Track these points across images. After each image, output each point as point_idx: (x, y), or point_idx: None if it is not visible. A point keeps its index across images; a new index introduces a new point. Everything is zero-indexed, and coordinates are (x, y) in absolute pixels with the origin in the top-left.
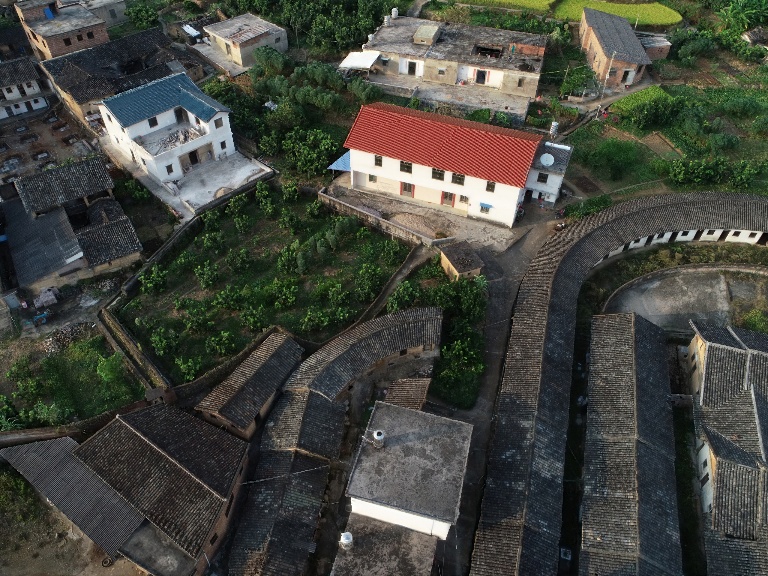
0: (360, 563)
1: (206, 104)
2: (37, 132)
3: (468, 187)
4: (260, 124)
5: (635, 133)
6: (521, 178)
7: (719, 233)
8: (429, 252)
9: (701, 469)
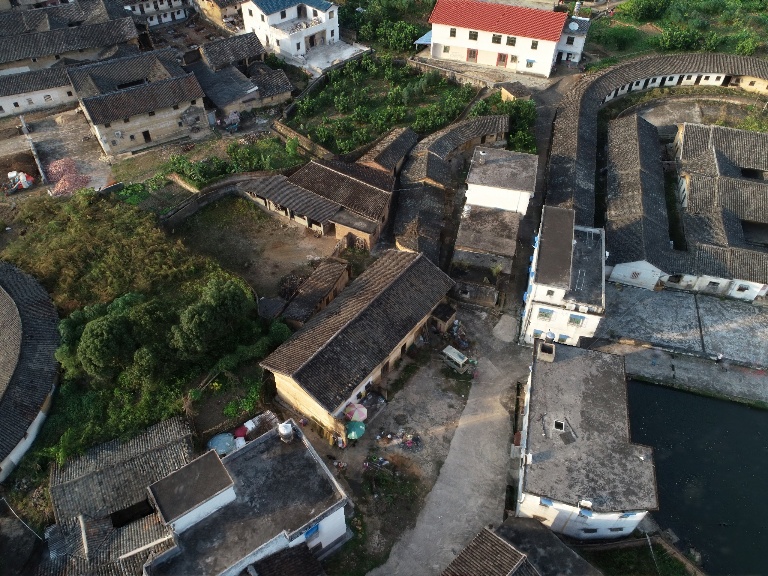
0: (476, 223)
1: (322, 0)
2: (185, 32)
3: (518, 47)
4: (358, 19)
5: (634, 24)
6: (556, 36)
7: (695, 78)
8: (492, 91)
9: (681, 196)
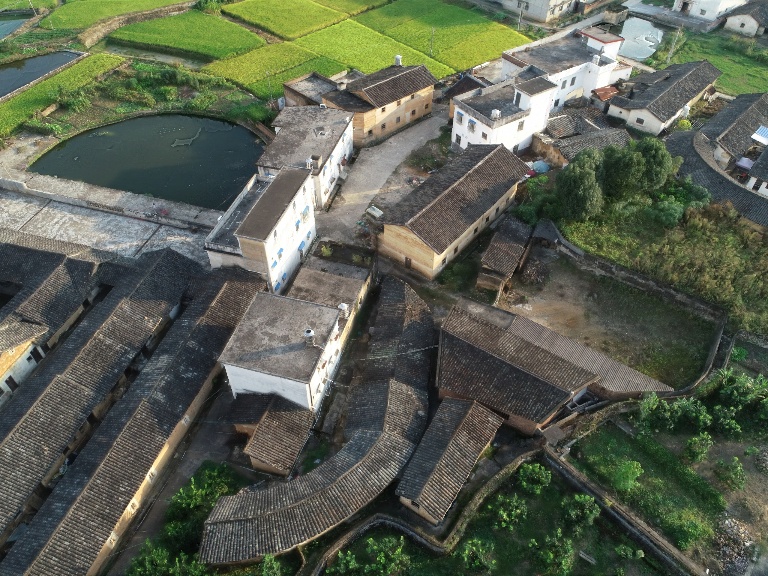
0: None
1: None
2: None
3: None
4: None
5: None
6: None
7: None
8: None
9: (4, 396)
